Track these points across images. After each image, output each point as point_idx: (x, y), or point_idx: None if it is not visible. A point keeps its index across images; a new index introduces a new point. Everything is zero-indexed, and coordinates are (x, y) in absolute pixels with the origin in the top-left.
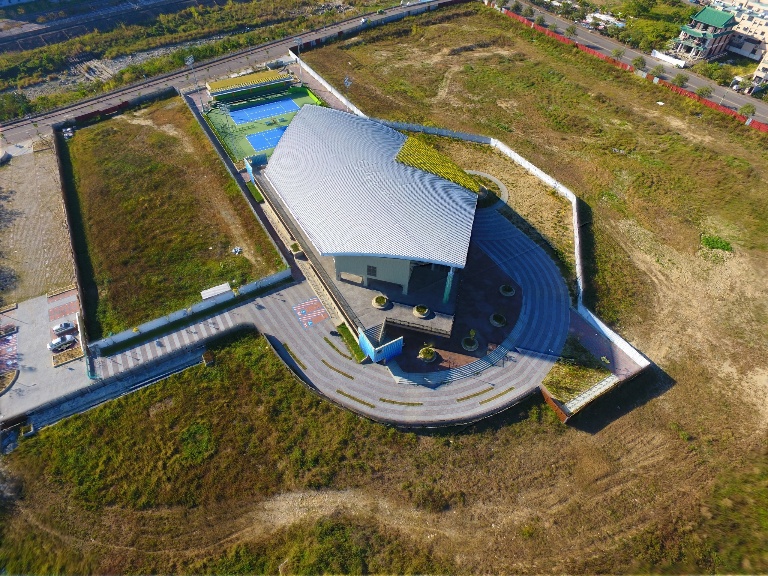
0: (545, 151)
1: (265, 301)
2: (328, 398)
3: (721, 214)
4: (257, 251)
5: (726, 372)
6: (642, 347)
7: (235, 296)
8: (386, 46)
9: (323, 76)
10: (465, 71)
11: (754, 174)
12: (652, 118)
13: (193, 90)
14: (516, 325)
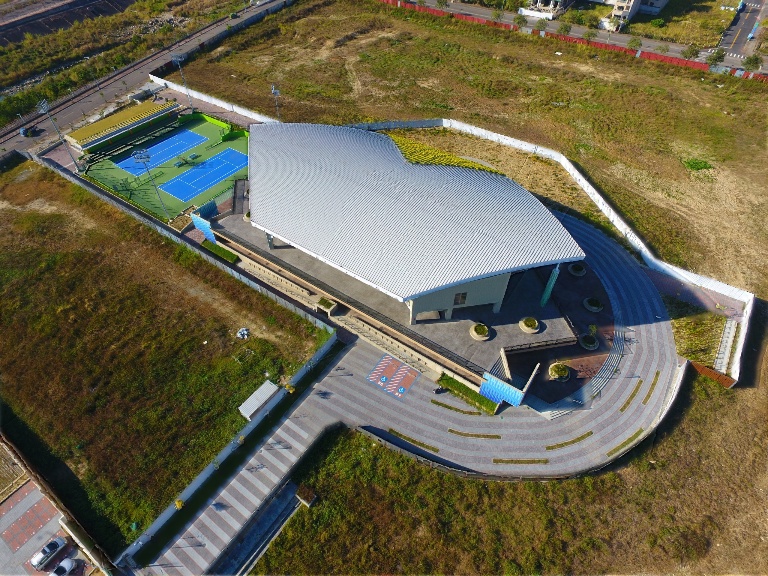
0: (498, 120)
1: (328, 385)
2: (491, 476)
3: (679, 138)
4: (270, 324)
5: None
6: (723, 281)
7: (284, 394)
8: (261, 50)
9: (212, 96)
10: (364, 60)
11: (675, 97)
12: (562, 68)
13: (46, 148)
14: (611, 303)
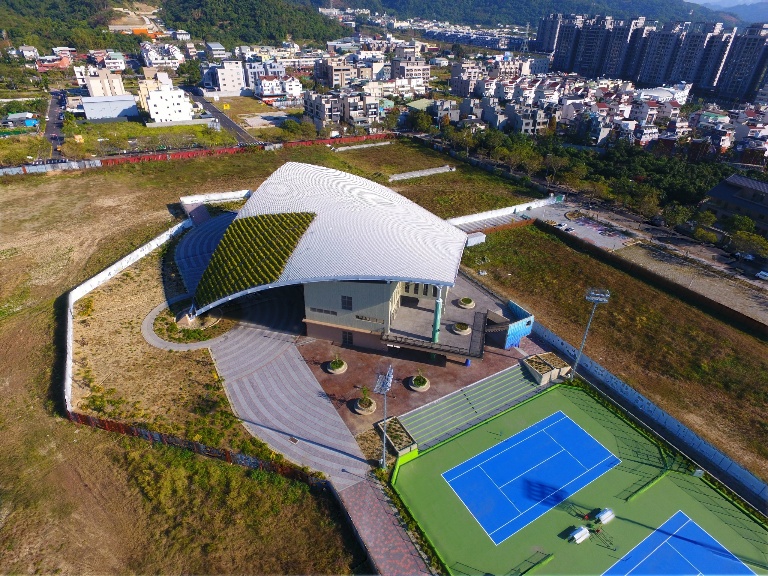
0: None
1: None
2: None
3: None
4: None
5: None
6: None
7: None
8: None
9: None
10: None
11: None
12: None
13: None
14: None
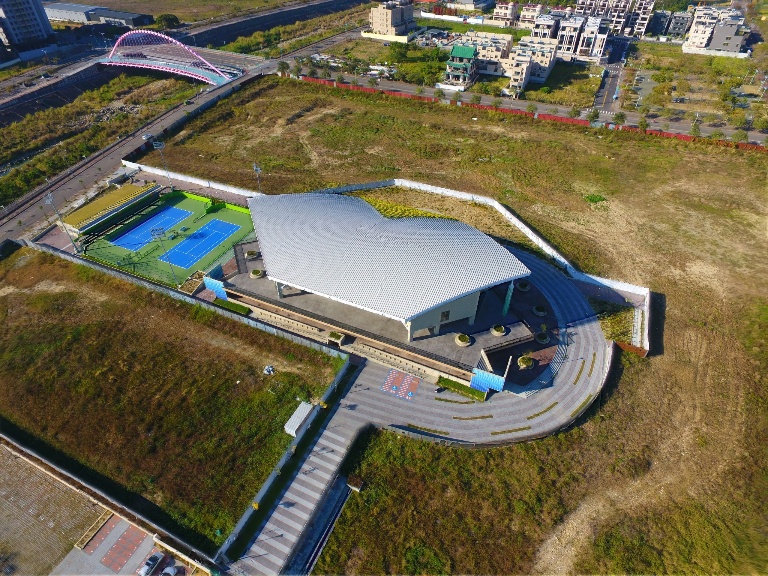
0: (438, 176)
1: (351, 399)
2: (491, 445)
3: (578, 179)
4: (290, 360)
5: (678, 274)
6: None
7: (317, 411)
8: (220, 131)
9: (186, 175)
10: (315, 134)
11: (569, 148)
12: (480, 130)
13: (39, 235)
14: (552, 308)
